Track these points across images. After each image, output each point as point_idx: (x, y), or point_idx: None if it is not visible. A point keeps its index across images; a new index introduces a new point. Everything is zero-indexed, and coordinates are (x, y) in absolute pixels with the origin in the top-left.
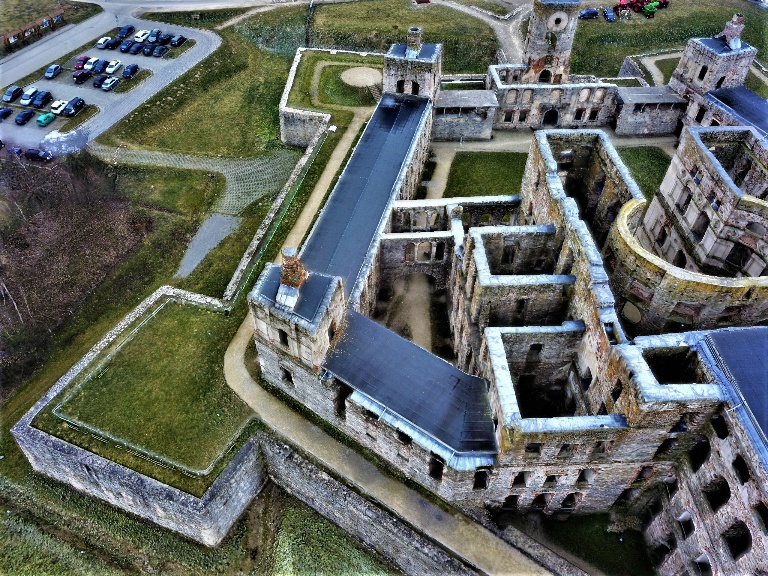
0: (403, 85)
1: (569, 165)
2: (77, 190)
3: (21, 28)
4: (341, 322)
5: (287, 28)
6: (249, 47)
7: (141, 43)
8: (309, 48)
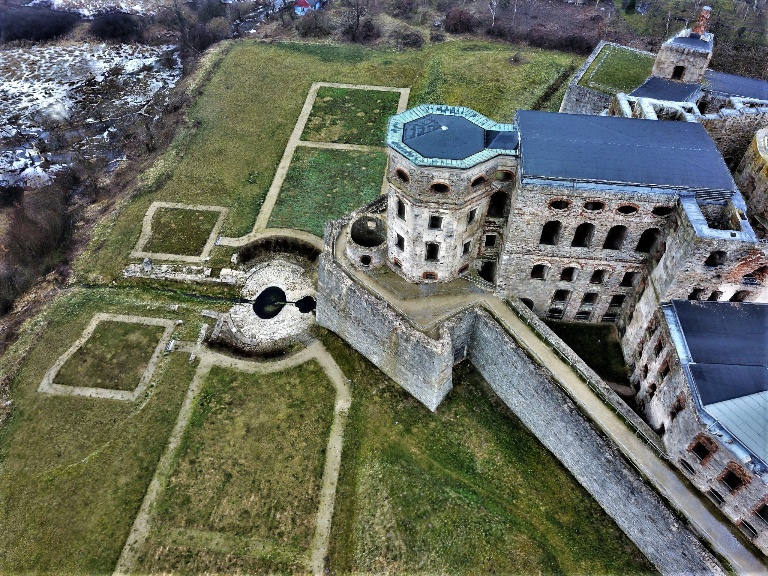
0: None
1: None
2: None
3: None
4: (689, 82)
5: None
6: None
7: None
8: None
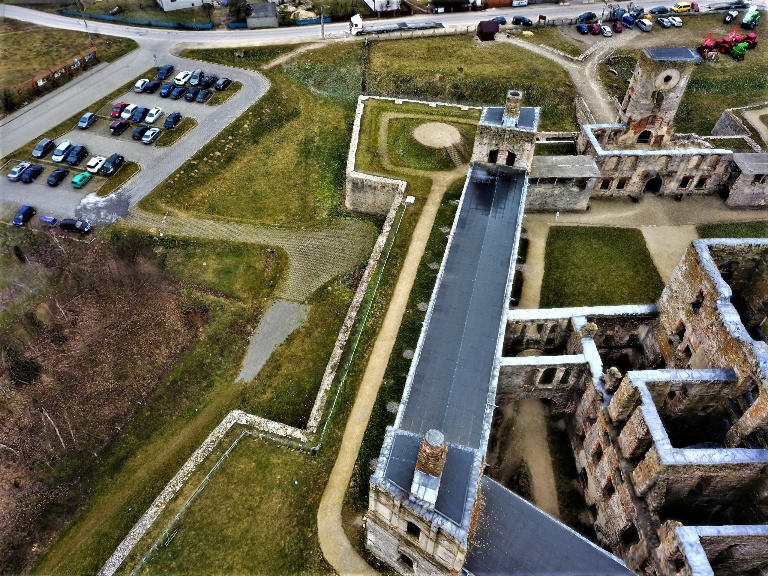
0: (497, 155)
1: (726, 277)
2: (121, 271)
3: (51, 69)
4: (477, 498)
5: (341, 69)
6: (299, 90)
7: (182, 86)
8: (371, 96)
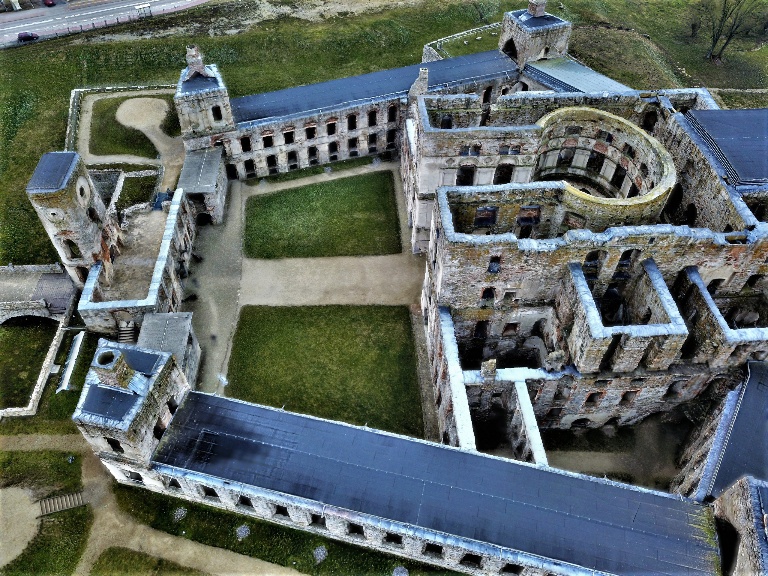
0: (160, 422)
1: None
2: None
3: None
4: None
5: None
6: None
7: None
8: None
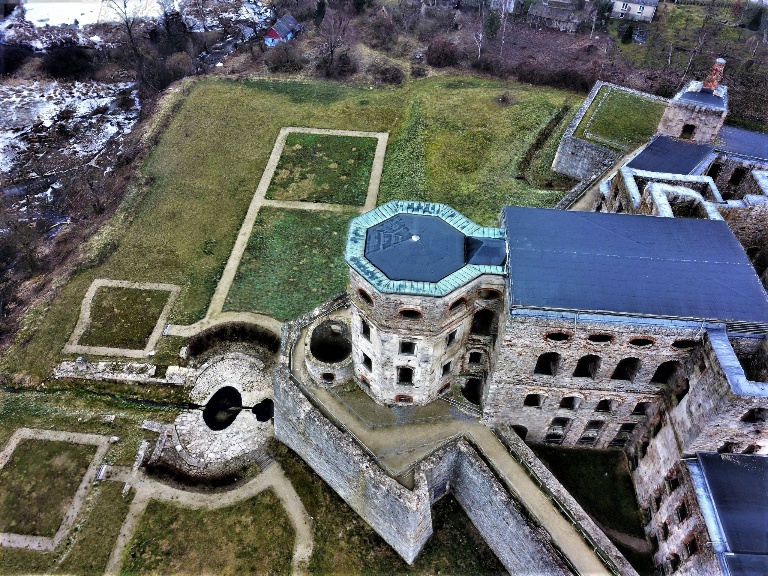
0: None
1: None
2: None
3: None
4: (701, 142)
5: None
6: None
7: None
8: None
